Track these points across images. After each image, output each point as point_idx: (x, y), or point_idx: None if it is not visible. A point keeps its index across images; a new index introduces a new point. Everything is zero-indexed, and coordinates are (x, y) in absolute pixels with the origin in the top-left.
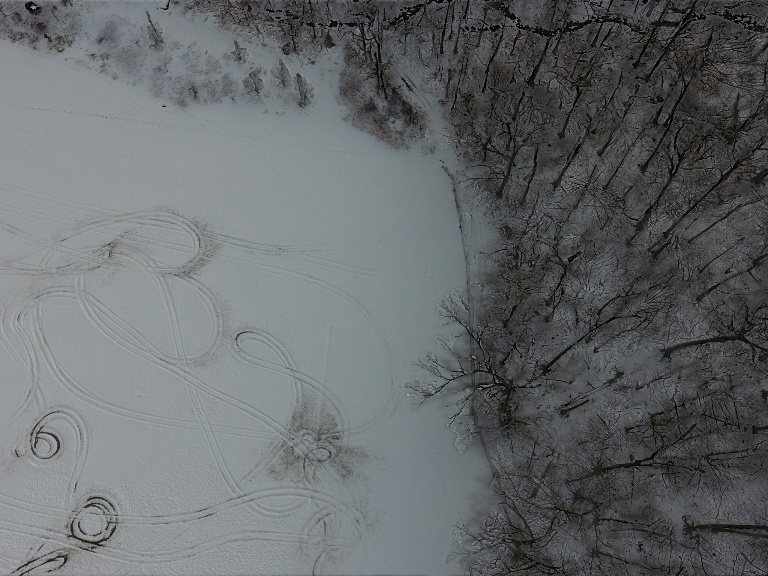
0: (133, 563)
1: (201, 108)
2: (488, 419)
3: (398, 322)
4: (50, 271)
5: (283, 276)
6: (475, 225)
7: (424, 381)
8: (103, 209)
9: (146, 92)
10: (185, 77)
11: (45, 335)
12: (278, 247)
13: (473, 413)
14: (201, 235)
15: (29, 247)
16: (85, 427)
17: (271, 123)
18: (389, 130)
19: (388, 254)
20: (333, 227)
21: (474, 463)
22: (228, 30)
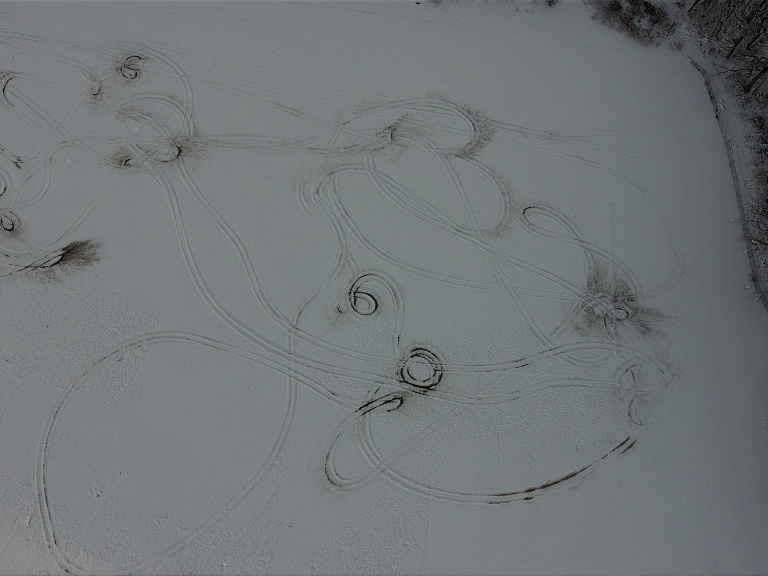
0: (464, 405)
1: (454, 5)
2: (767, 286)
3: (672, 200)
4: (339, 150)
5: (558, 158)
6: (728, 116)
7: (760, 232)
8: (378, 95)
9: None
10: None
11: (345, 207)
12: (549, 132)
13: (754, 280)
14: (475, 120)
15: (315, 129)
16: (398, 288)
17: (523, 20)
18: (636, 28)
19: (653, 140)
20: (598, 115)
21: (760, 323)
22: None
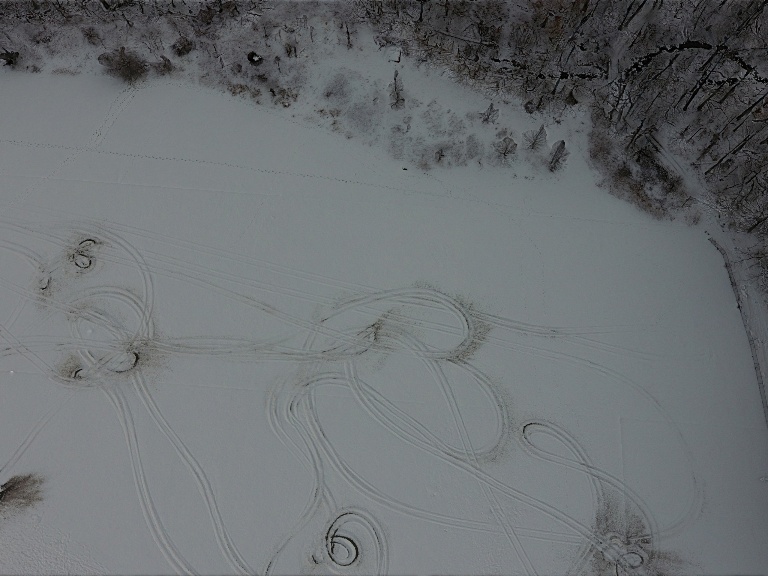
0: None
1: (445, 172)
2: None
3: (690, 413)
4: (316, 355)
5: (562, 361)
6: (751, 304)
7: None
8: (360, 286)
9: (384, 153)
10: (427, 138)
11: (322, 427)
12: (551, 329)
13: None
14: (468, 315)
15: (289, 328)
16: (381, 530)
17: (521, 189)
18: (647, 198)
19: (668, 337)
20: (606, 307)
21: None
22: (466, 86)
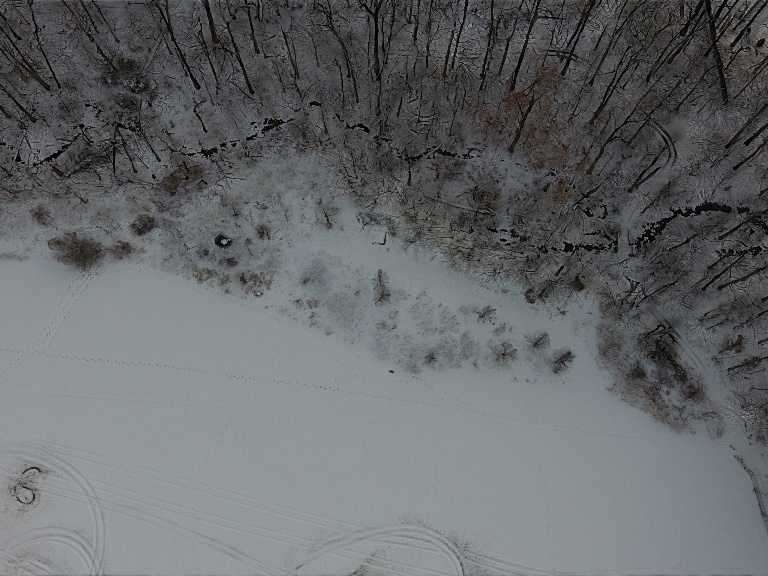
0: None
1: (436, 375)
2: None
3: None
4: None
5: None
6: None
7: None
8: (340, 522)
9: (368, 352)
10: (416, 336)
11: None
12: (558, 574)
13: None
14: (463, 558)
15: None
16: None
17: (522, 395)
18: (664, 405)
19: None
20: (619, 545)
21: None
22: (460, 272)
